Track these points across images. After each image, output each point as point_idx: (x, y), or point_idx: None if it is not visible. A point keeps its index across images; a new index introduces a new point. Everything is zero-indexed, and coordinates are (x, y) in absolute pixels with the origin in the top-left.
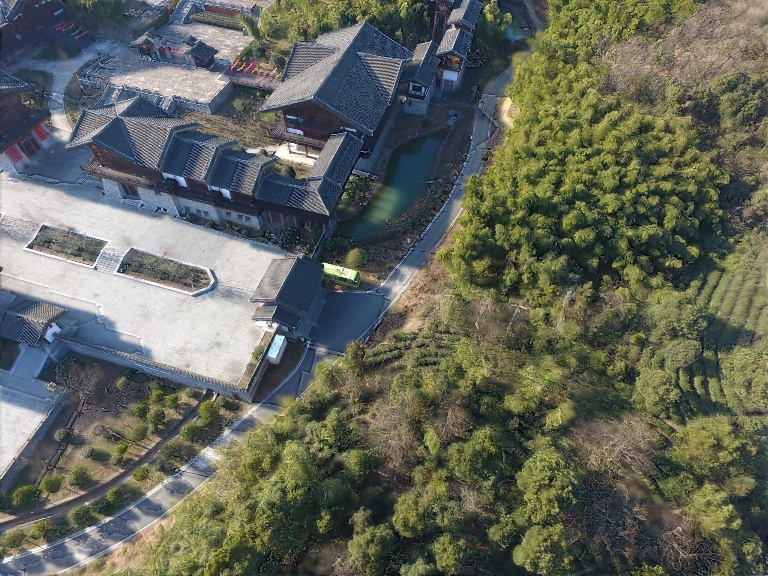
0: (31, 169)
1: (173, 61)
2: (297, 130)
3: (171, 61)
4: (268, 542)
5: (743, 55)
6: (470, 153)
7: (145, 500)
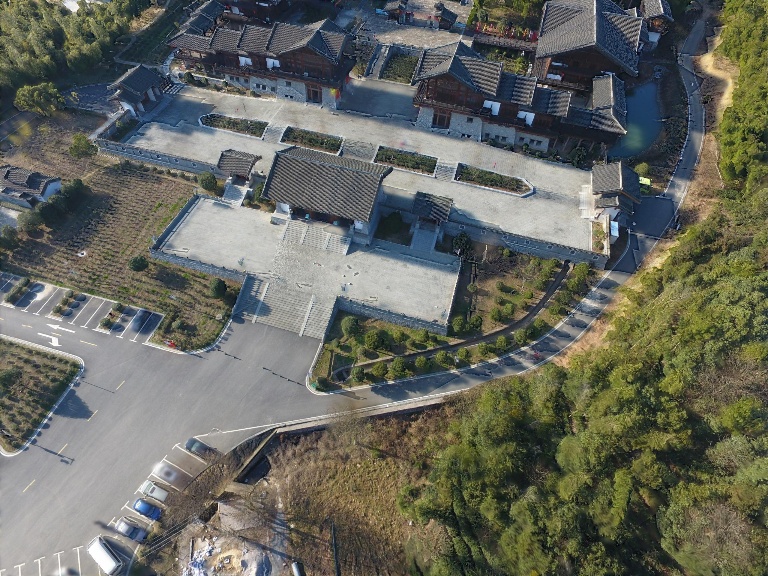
0: (344, 106)
1: (416, 25)
2: (556, 76)
3: (414, 25)
4: (767, 307)
5: None
6: (689, 98)
7: (556, 331)
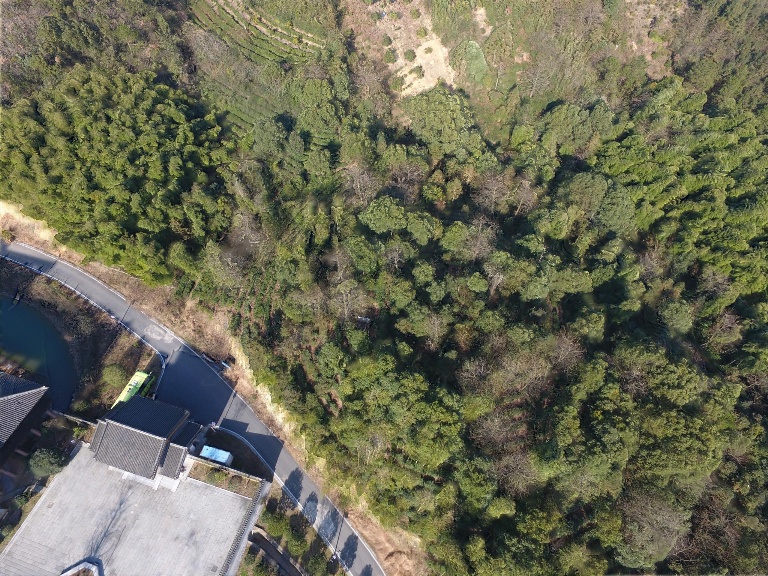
0: None
1: None
2: None
3: None
4: (423, 378)
5: (19, 8)
6: None
7: None
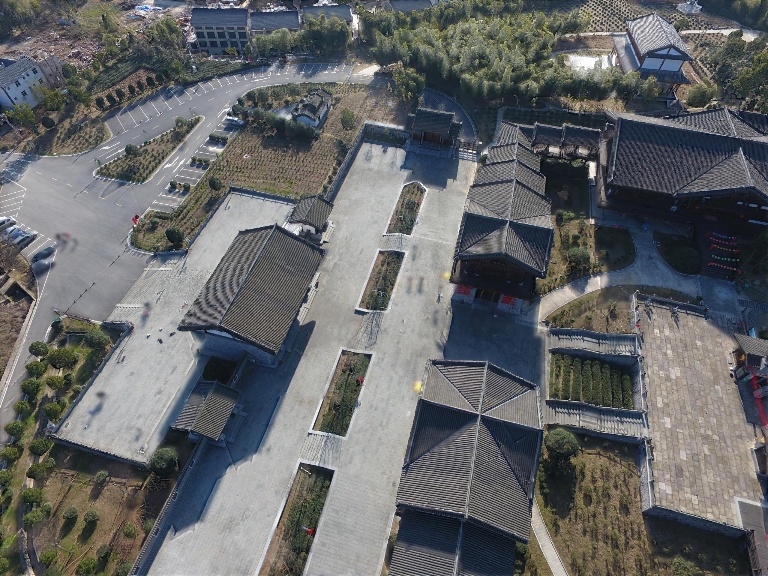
0: (461, 307)
1: (750, 404)
2: None
3: (748, 401)
4: None
5: None
6: None
7: None
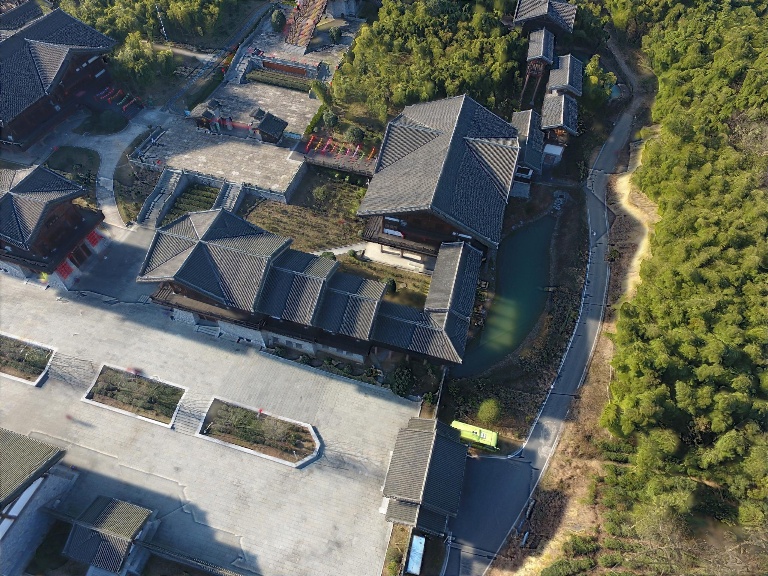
0: (82, 283)
1: (235, 134)
2: (396, 232)
3: (232, 134)
4: None
5: None
6: (591, 251)
7: None
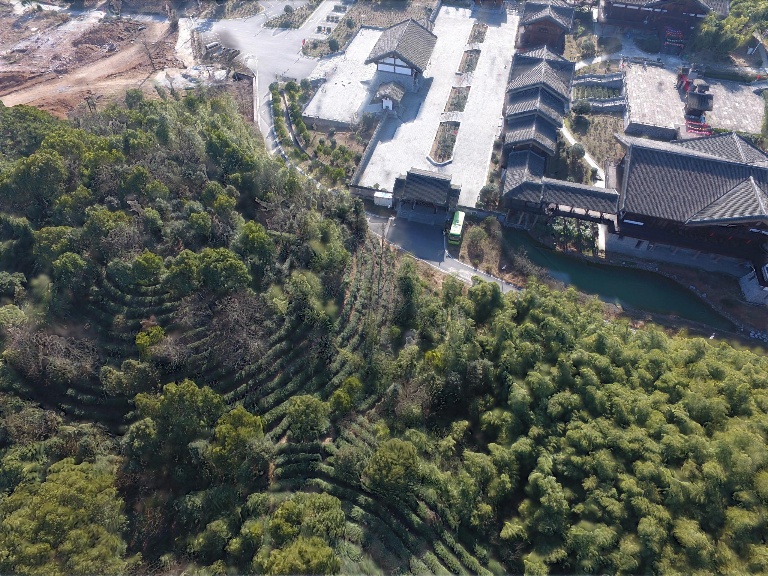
0: None
1: (683, 96)
2: None
3: (683, 95)
4: None
5: None
6: None
7: None
